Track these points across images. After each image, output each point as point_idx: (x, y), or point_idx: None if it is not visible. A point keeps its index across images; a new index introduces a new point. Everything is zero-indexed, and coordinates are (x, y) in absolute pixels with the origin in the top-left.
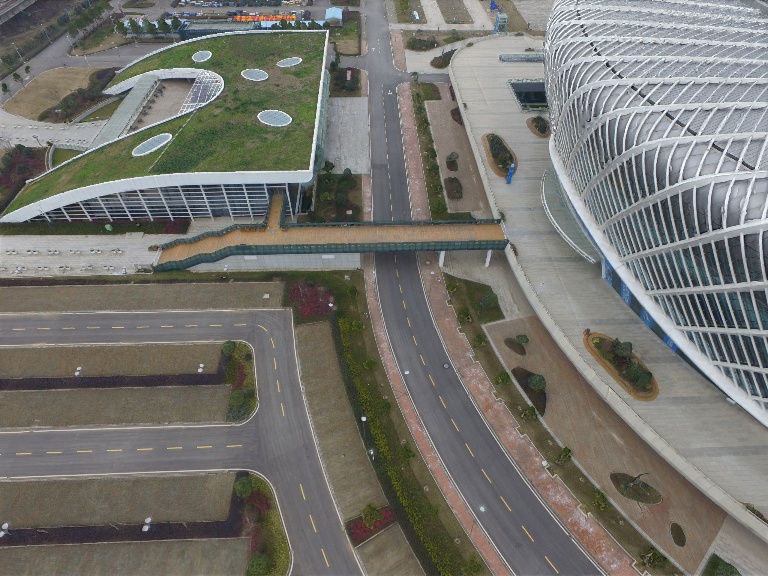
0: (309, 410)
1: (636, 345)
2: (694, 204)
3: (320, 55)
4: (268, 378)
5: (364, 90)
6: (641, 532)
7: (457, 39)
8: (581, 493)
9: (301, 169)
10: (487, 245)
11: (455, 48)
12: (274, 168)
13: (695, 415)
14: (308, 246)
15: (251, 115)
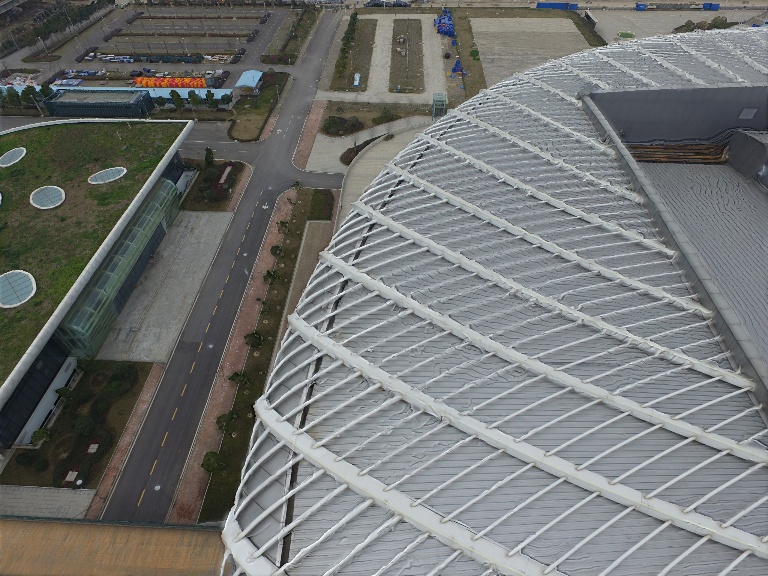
0: None
1: None
2: None
3: (155, 164)
4: None
5: (234, 200)
6: None
7: (390, 119)
8: None
9: None
10: None
11: (382, 133)
12: None
13: None
14: None
15: None
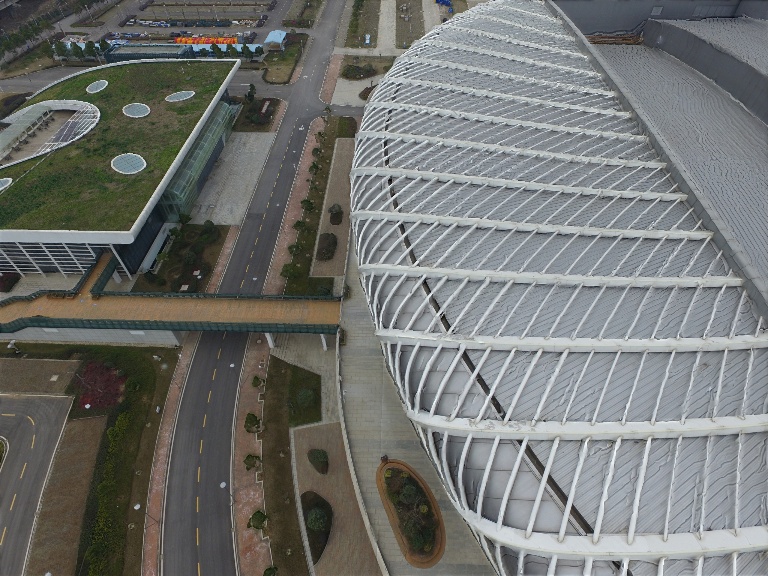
0: (33, 539)
1: (440, 482)
2: (390, 364)
3: (216, 88)
4: (6, 490)
5: (275, 124)
6: None
7: None
8: None
9: (123, 229)
10: (315, 329)
11: None
12: (95, 226)
13: None
14: (109, 322)
15: (106, 159)
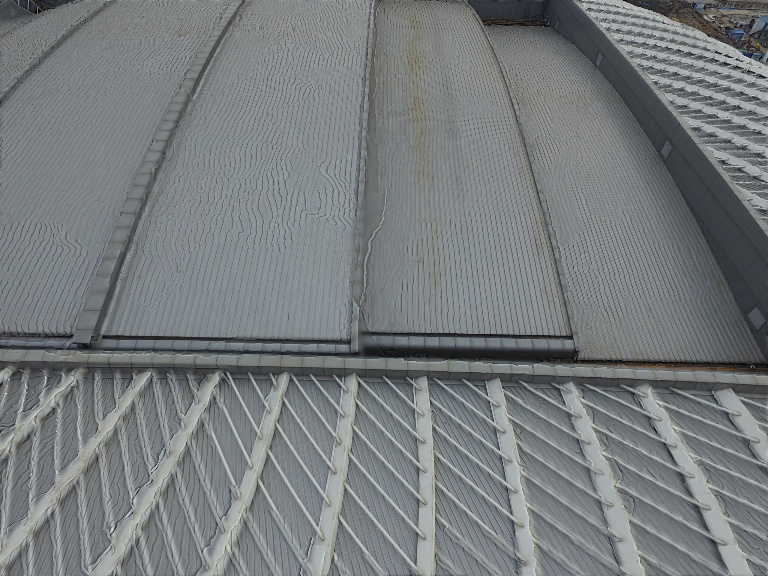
0: None
1: None
2: None
3: None
4: None
5: None
6: None
7: None
8: None
9: None
10: None
11: None
12: None
13: None
14: None
15: None
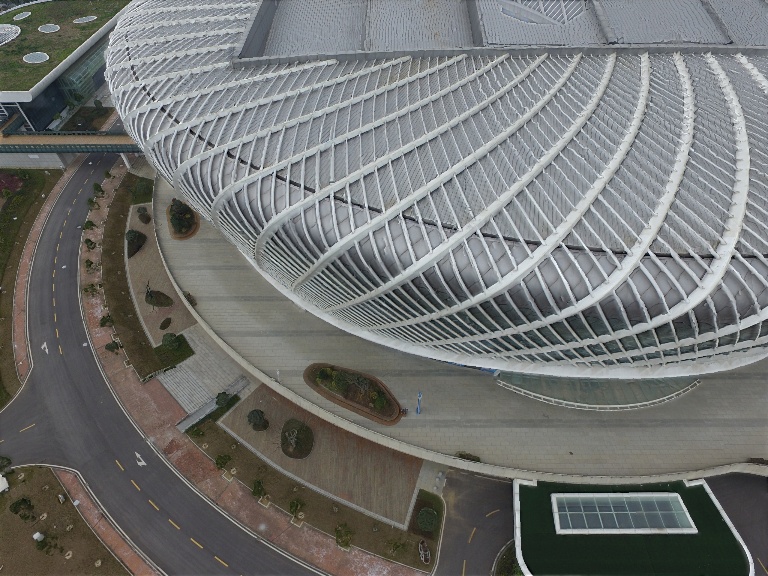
0: None
1: None
2: None
3: None
4: None
5: None
6: (142, 322)
7: None
8: (112, 298)
9: None
10: None
11: None
12: (5, 90)
13: (207, 248)
14: (13, 146)
15: (20, 56)
